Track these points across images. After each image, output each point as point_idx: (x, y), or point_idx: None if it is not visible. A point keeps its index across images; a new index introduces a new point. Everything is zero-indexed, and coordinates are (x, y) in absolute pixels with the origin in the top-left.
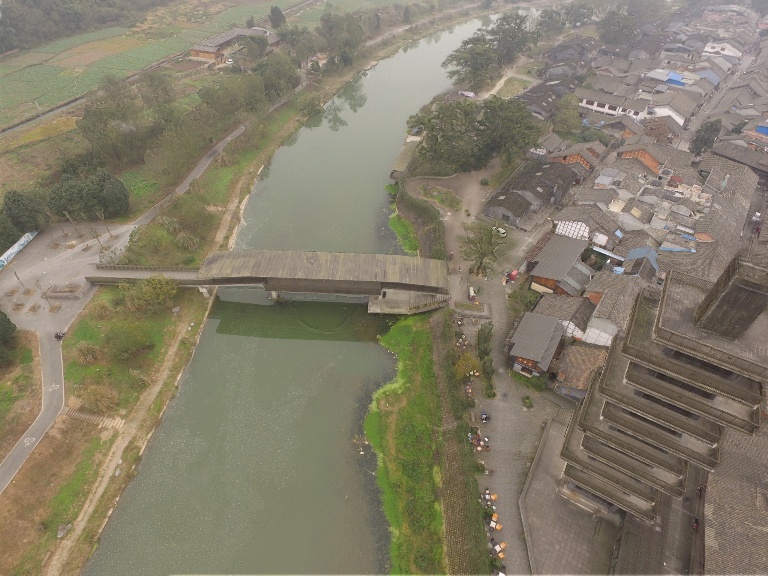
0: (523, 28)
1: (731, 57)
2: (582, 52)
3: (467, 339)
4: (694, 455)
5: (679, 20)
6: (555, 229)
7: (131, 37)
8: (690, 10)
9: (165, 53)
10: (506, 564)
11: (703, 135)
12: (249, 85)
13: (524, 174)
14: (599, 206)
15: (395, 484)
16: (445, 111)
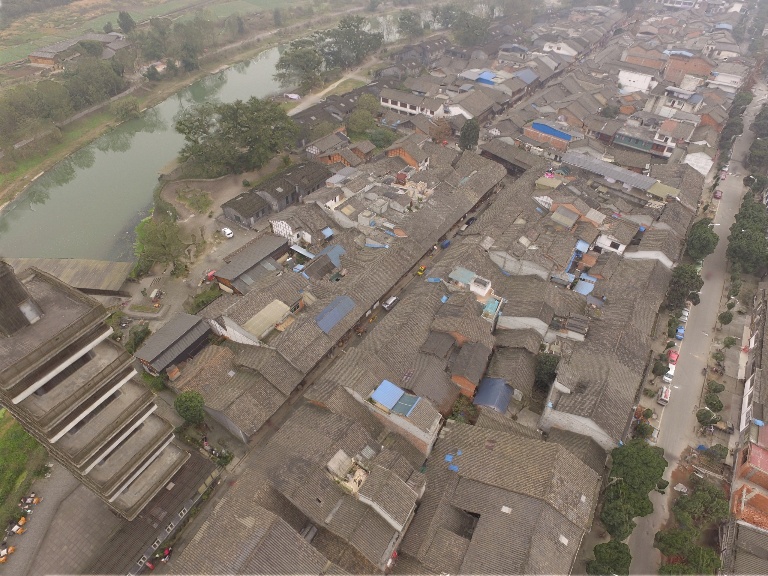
0: (365, 30)
1: (567, 56)
2: (424, 53)
3: (122, 341)
4: None
5: (544, 21)
6: (272, 229)
7: None
8: (561, 11)
9: (8, 60)
10: (5, 568)
11: (465, 132)
12: (45, 91)
13: (278, 175)
14: (319, 205)
15: None
16: (199, 113)
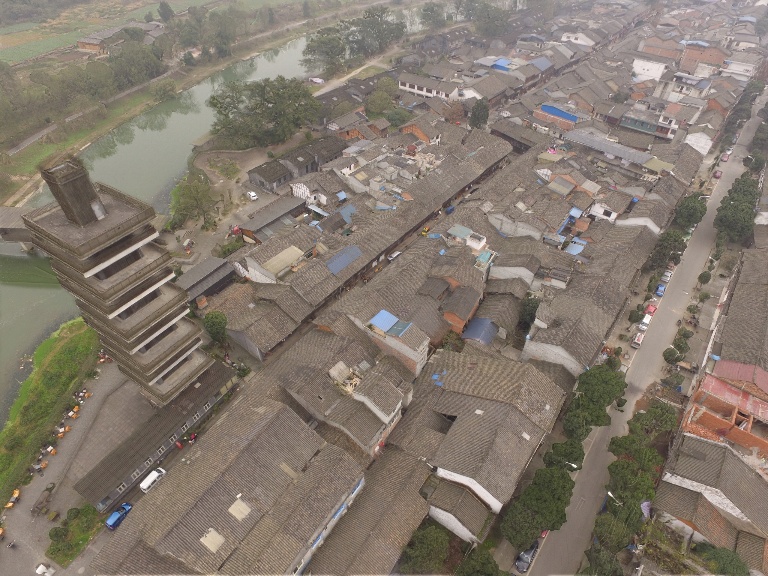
0: (389, 20)
1: (584, 46)
2: (444, 42)
3: None
4: (115, 329)
5: (566, 13)
6: (292, 192)
7: (37, 32)
8: (584, 4)
9: (58, 46)
10: (63, 441)
11: (475, 112)
12: (94, 71)
13: (300, 147)
14: (335, 171)
15: (31, 390)
16: (230, 90)
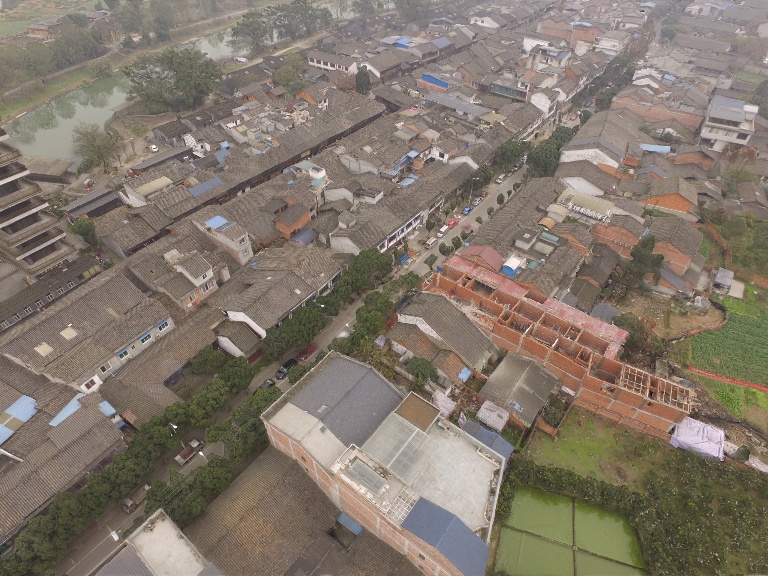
0: (314, 6)
1: (489, 28)
2: (364, 26)
3: None
4: None
5: (489, 1)
6: (185, 143)
7: None
8: None
9: (11, 32)
10: None
11: (357, 79)
12: (32, 50)
13: None
14: (222, 126)
15: None
16: (141, 61)
